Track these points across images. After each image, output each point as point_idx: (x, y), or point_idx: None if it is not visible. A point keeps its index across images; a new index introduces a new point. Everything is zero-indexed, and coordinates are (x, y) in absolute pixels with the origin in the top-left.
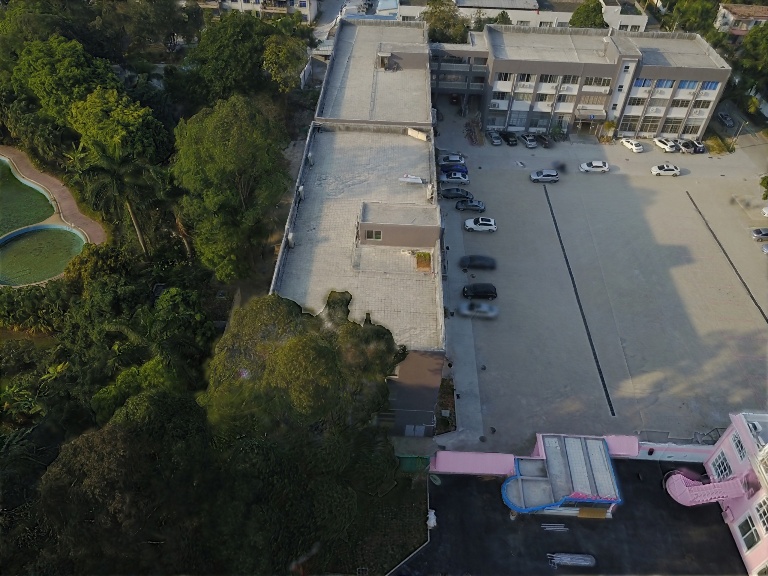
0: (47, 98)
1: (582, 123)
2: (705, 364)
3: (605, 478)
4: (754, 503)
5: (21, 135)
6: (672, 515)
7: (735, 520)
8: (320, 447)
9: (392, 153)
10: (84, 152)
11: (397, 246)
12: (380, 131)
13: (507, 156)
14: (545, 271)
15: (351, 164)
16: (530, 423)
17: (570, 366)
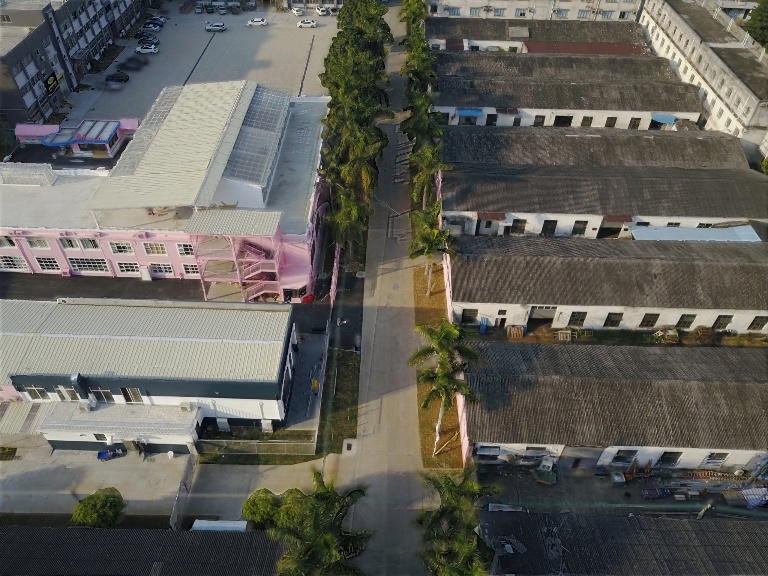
0: None
1: None
2: None
3: (107, 134)
4: None
5: None
6: None
7: None
8: None
9: None
10: None
11: (23, 27)
12: None
13: (201, 19)
14: (174, 72)
15: None
16: None
17: None
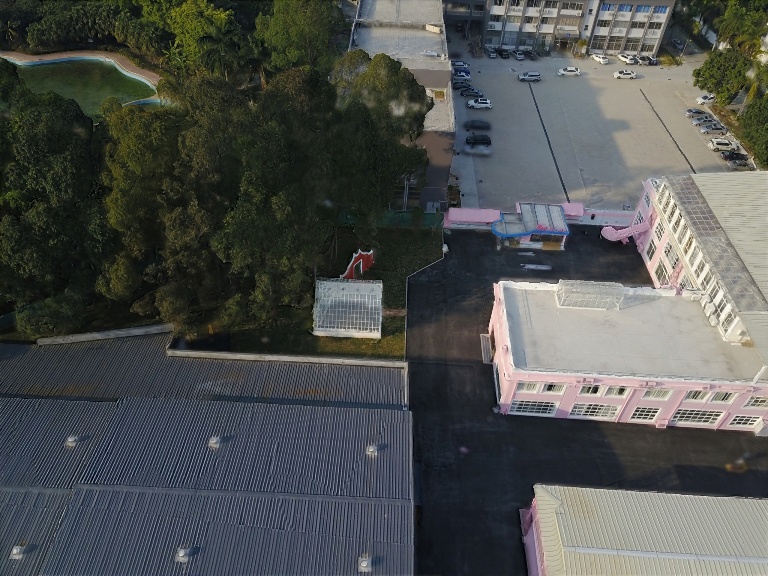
0: (151, 6)
1: (561, 42)
2: (639, 183)
3: (560, 223)
4: (654, 228)
5: (126, 39)
6: (604, 250)
7: (645, 248)
8: (390, 119)
9: (414, 40)
10: (178, 48)
11: None
12: (405, 27)
13: (501, 65)
14: (527, 132)
15: (385, 45)
16: (512, 209)
17: (542, 182)
